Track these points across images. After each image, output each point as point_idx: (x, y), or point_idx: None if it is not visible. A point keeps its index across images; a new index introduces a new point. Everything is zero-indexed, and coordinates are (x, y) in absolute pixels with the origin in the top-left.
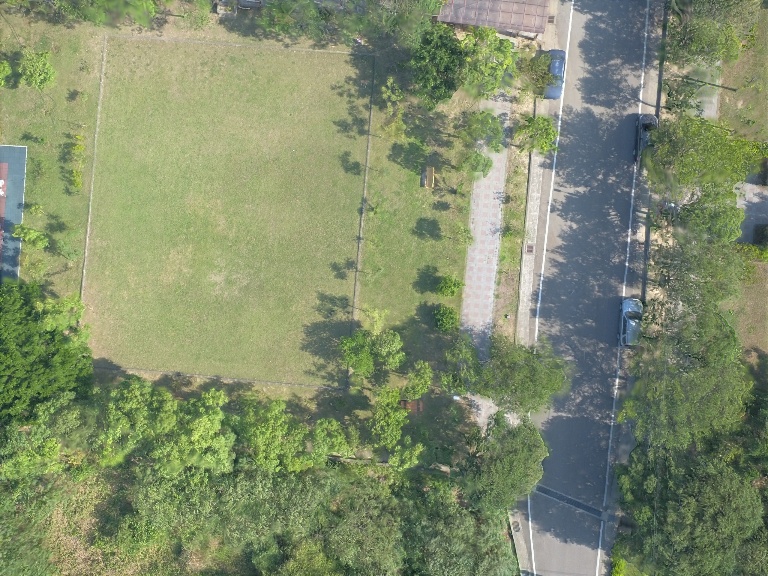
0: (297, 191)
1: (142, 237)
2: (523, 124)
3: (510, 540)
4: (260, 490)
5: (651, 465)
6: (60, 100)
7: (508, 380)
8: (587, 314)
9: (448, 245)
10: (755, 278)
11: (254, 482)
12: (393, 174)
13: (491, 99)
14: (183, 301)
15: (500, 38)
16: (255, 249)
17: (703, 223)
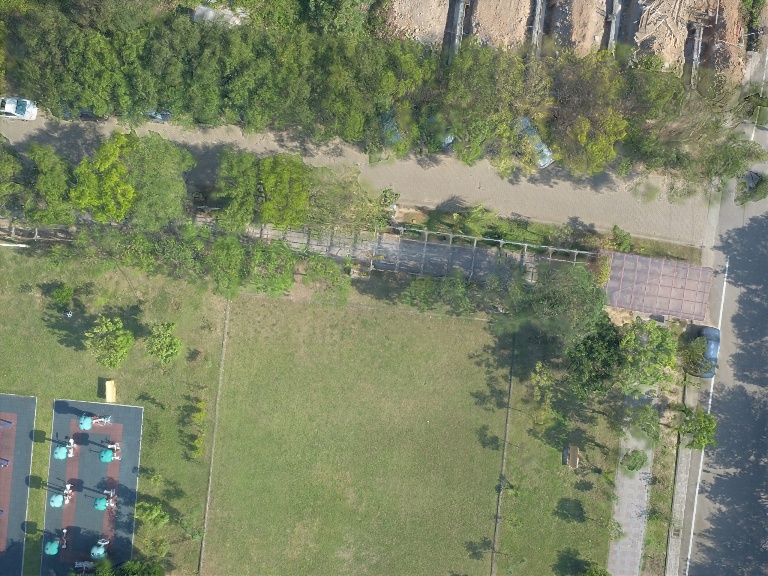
0: (431, 465)
1: (266, 508)
2: (672, 403)
3: None
4: None
5: None
6: (180, 360)
7: None
8: None
9: (590, 527)
10: None
11: None
12: (533, 450)
13: None
14: None
15: None
16: (386, 525)
17: None
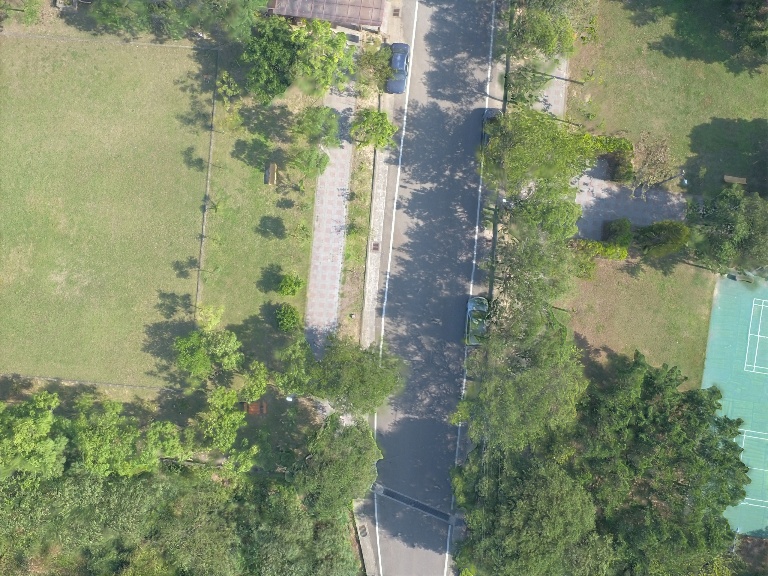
0: (139, 188)
1: None
2: None
3: (357, 545)
4: (89, 495)
5: (485, 467)
6: None
7: (340, 381)
8: (434, 313)
9: (292, 243)
10: (604, 276)
11: (83, 487)
12: (236, 171)
13: (335, 94)
14: (23, 301)
15: (344, 31)
16: (96, 248)
17: (535, 219)
